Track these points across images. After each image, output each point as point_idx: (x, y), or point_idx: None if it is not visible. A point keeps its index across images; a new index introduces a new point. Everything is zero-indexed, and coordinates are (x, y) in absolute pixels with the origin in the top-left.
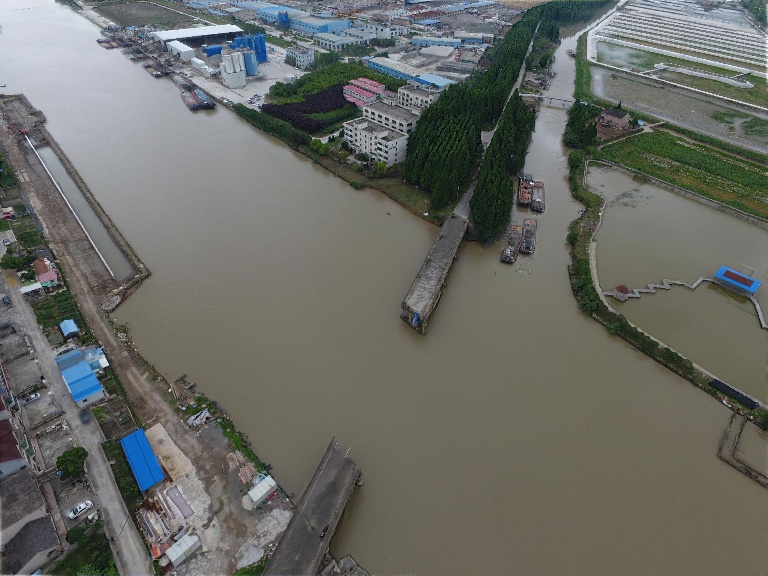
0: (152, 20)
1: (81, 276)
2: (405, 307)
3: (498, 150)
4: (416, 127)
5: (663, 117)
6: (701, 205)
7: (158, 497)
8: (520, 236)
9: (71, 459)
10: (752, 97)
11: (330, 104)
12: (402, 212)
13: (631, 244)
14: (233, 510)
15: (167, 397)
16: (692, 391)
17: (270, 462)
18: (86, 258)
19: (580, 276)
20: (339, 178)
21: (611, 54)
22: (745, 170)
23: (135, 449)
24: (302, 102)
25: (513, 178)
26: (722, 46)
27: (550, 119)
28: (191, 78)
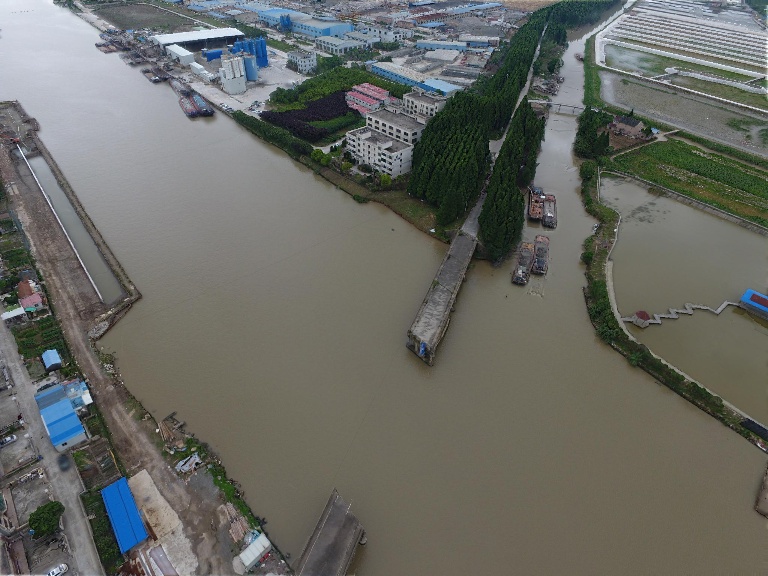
0: (152, 23)
1: (68, 299)
2: (411, 336)
3: (508, 162)
4: (421, 137)
5: (677, 125)
6: (721, 220)
7: (140, 558)
8: (532, 254)
9: (45, 517)
10: (767, 103)
11: (332, 111)
12: (407, 228)
13: (649, 264)
14: (223, 574)
15: (154, 439)
16: (722, 431)
17: (264, 515)
18: (74, 279)
19: (597, 300)
20: (341, 191)
21: (620, 58)
22: (765, 182)
23: (117, 502)
24: (303, 109)
25: (523, 191)
26: (733, 49)
27: (559, 127)
28: (190, 83)
